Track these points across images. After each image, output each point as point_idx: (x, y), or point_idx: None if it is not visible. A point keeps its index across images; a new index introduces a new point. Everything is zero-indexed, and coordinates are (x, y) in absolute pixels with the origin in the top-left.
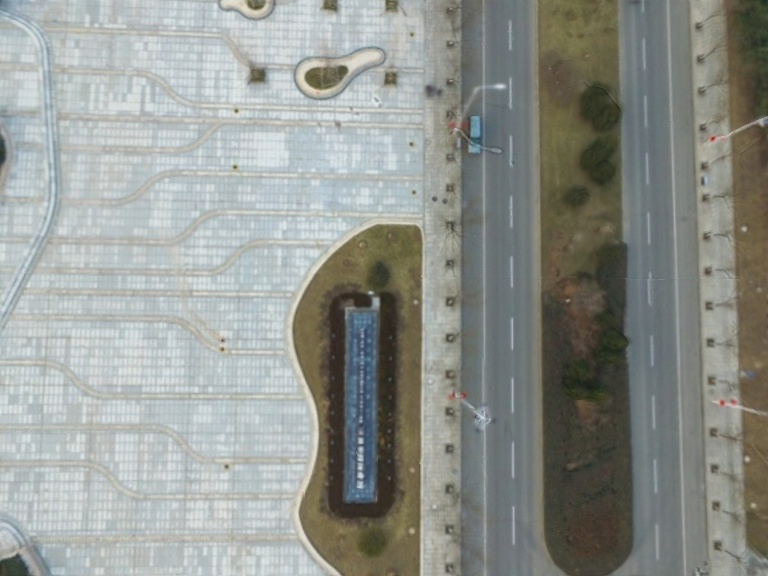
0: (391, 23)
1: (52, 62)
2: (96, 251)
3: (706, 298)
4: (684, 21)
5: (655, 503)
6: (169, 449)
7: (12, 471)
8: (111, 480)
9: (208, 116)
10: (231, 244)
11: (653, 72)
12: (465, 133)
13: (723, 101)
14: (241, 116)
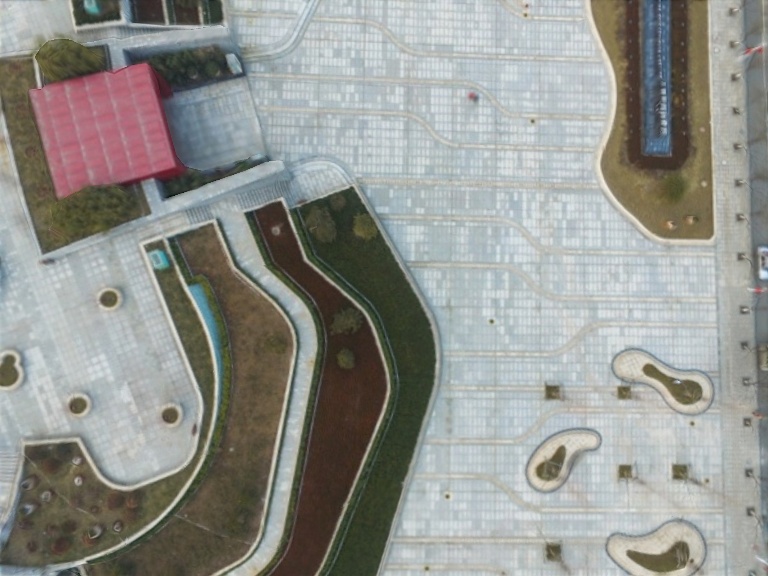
0: None
1: None
2: None
3: None
4: None
5: None
6: (480, 104)
7: (338, 118)
8: (428, 130)
9: None
10: None
11: None
12: None
13: None
14: None
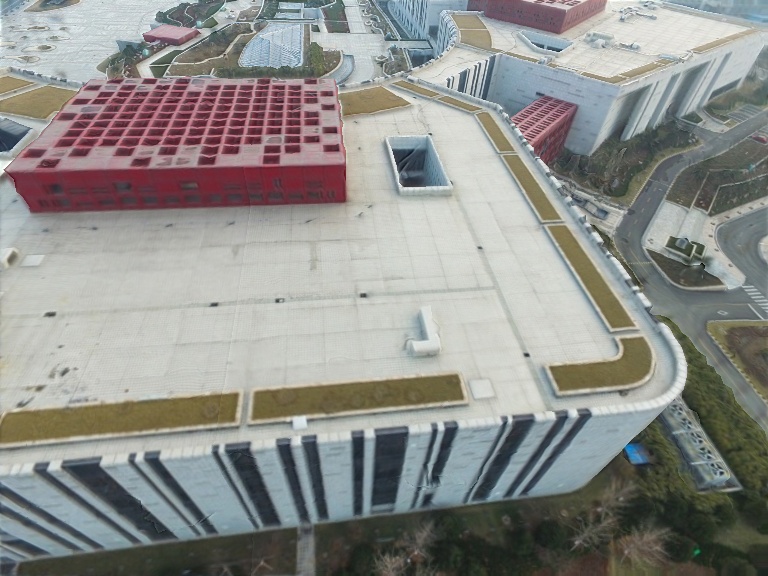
0: None
1: None
2: None
3: None
4: None
5: None
6: None
7: None
8: None
9: None
10: None
11: None
12: None
13: None
14: None
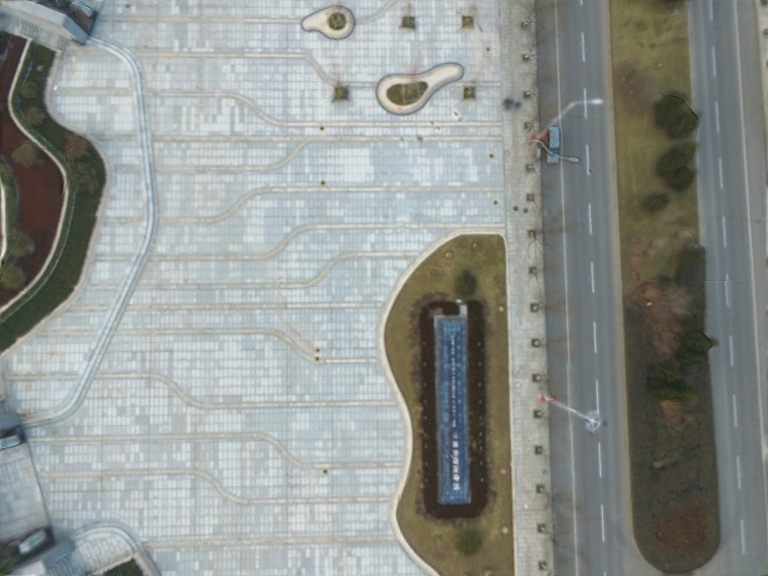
0: (468, 39)
1: (145, 86)
2: (194, 267)
3: None
4: (752, 28)
5: (739, 499)
6: (270, 456)
7: (122, 480)
8: (216, 487)
9: (295, 134)
10: (322, 257)
11: (723, 79)
12: (545, 144)
13: None
14: (327, 133)
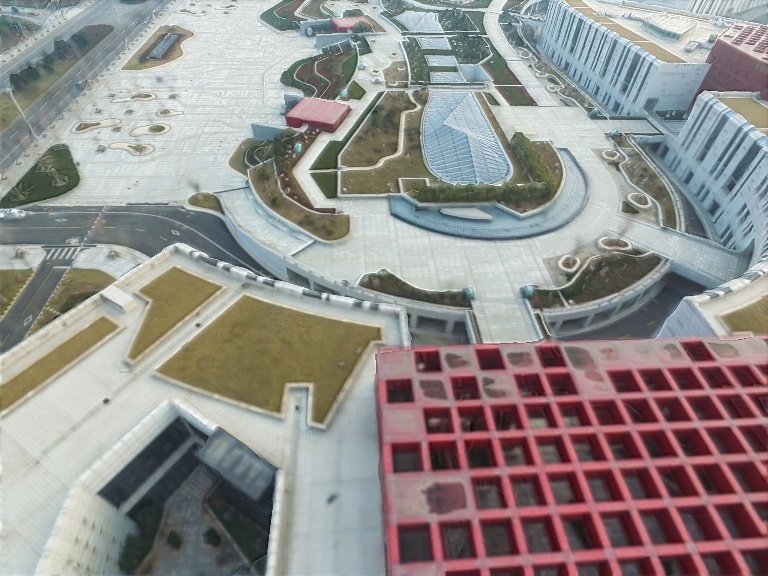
0: None
1: None
2: None
3: (11, 58)
4: None
5: (70, 33)
6: None
7: None
8: None
9: None
10: None
11: None
12: None
13: None
14: None
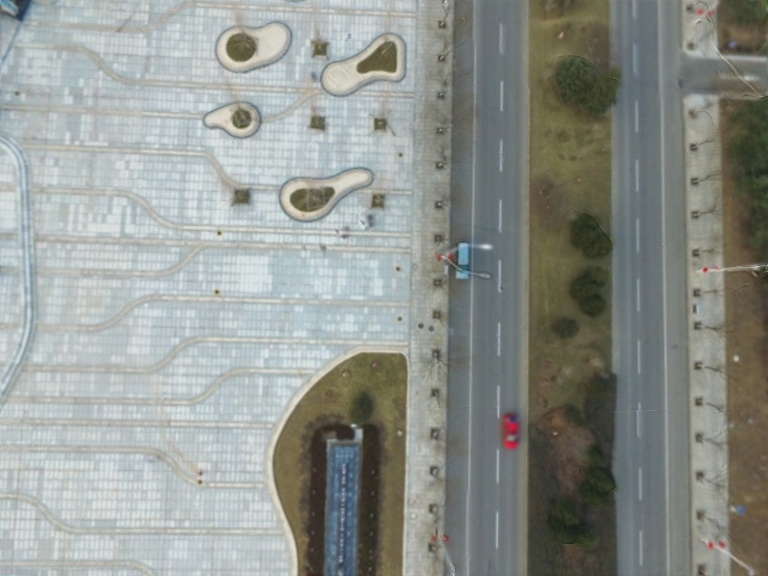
0: (379, 143)
1: (30, 181)
2: (72, 379)
3: (696, 430)
4: (678, 142)
5: None
6: None
7: None
8: None
9: (190, 238)
10: (211, 372)
11: (646, 195)
12: (453, 261)
13: (716, 229)
14: (224, 238)
